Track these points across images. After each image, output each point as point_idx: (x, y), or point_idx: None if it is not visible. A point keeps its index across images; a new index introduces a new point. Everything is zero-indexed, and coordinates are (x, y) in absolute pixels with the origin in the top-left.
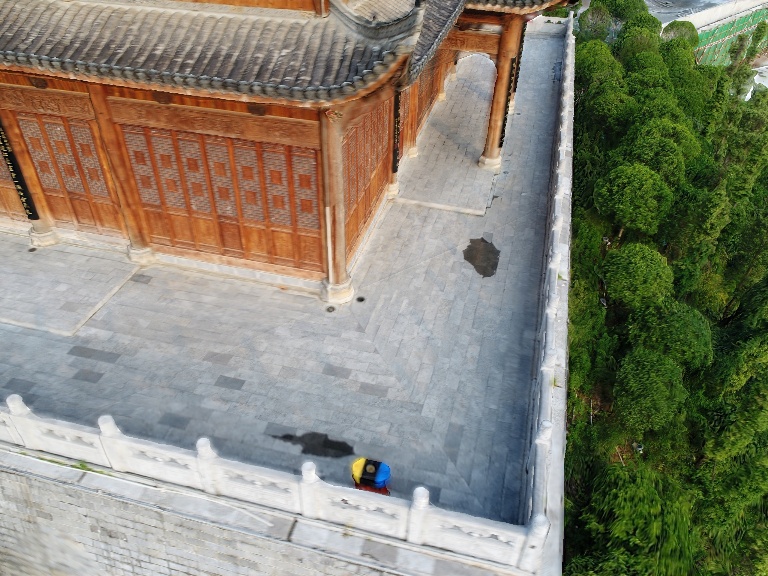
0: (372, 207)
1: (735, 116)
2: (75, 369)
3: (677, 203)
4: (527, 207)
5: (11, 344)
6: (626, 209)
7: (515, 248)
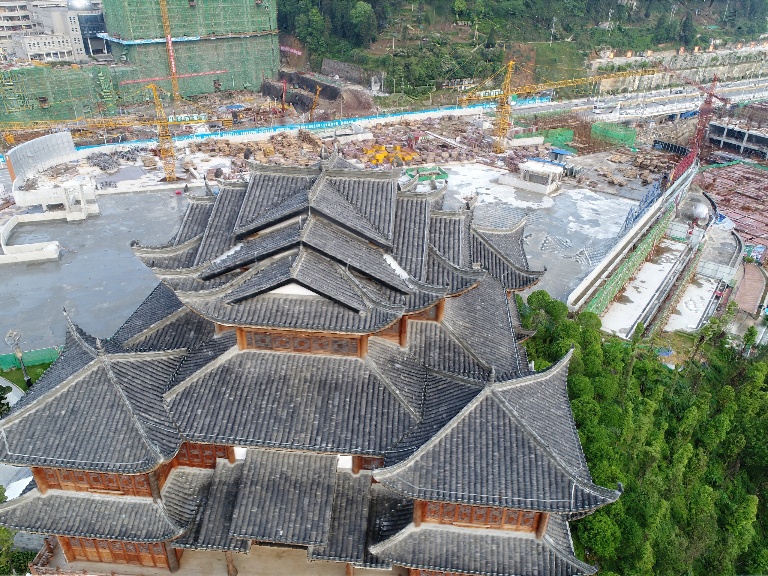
0: None
1: (640, 441)
2: None
3: (622, 533)
4: None
5: None
6: (599, 549)
7: None
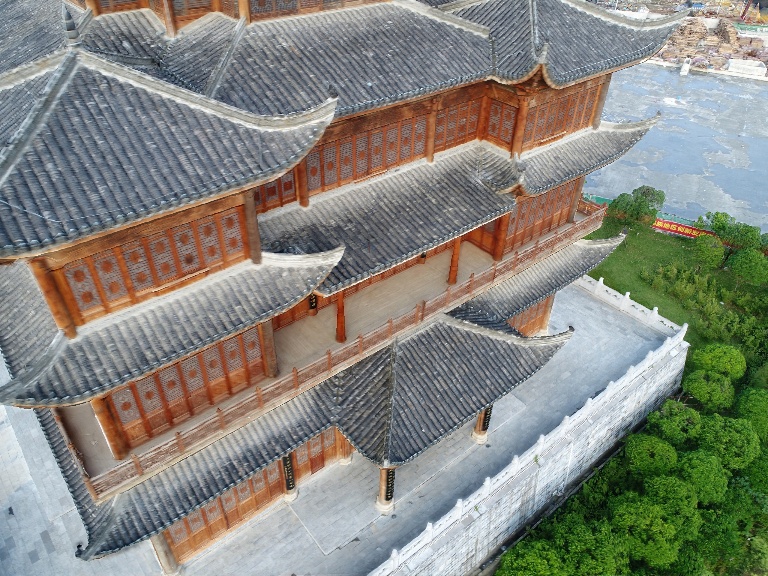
0: (246, 516)
1: None
2: (34, 547)
3: None
4: (364, 565)
5: (29, 510)
6: None
7: None
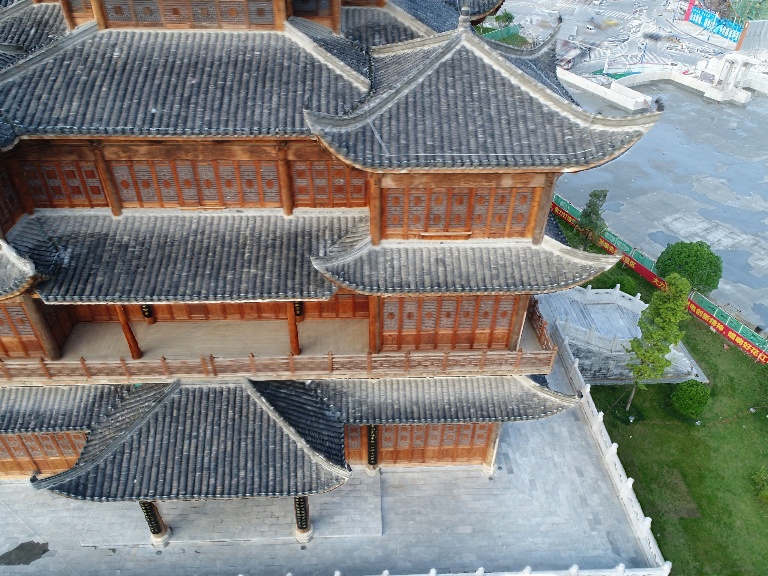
0: None
1: None
2: None
3: None
4: None
5: None
6: None
7: (31, 574)
